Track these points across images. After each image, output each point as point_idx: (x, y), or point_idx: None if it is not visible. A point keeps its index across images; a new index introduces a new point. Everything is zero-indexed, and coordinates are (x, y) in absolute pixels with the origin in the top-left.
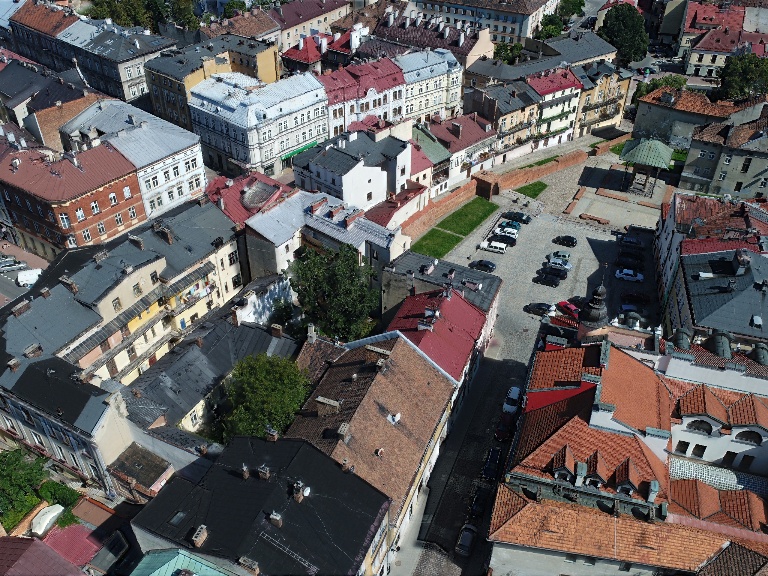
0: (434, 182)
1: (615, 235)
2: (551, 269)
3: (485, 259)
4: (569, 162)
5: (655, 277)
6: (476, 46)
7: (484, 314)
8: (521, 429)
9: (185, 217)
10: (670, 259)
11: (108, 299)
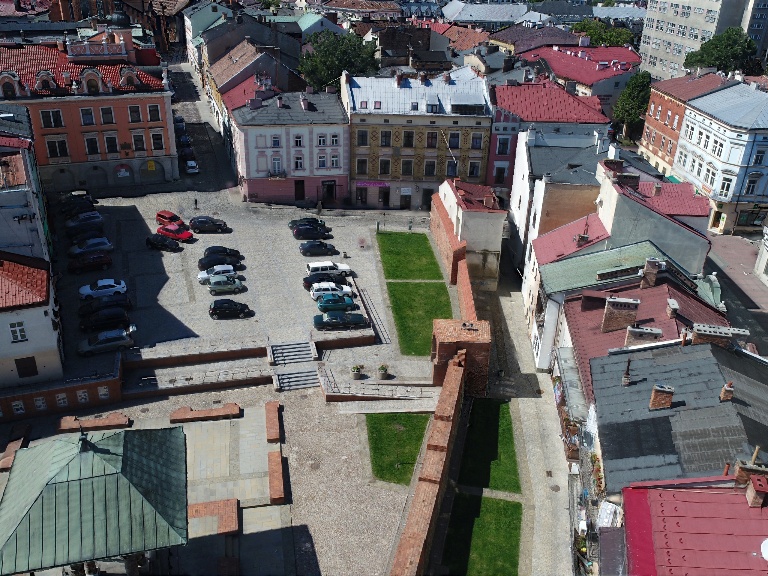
0: None
1: None
2: None
3: None
4: None
5: None
6: None
7: None
8: None
9: None
10: None
11: None
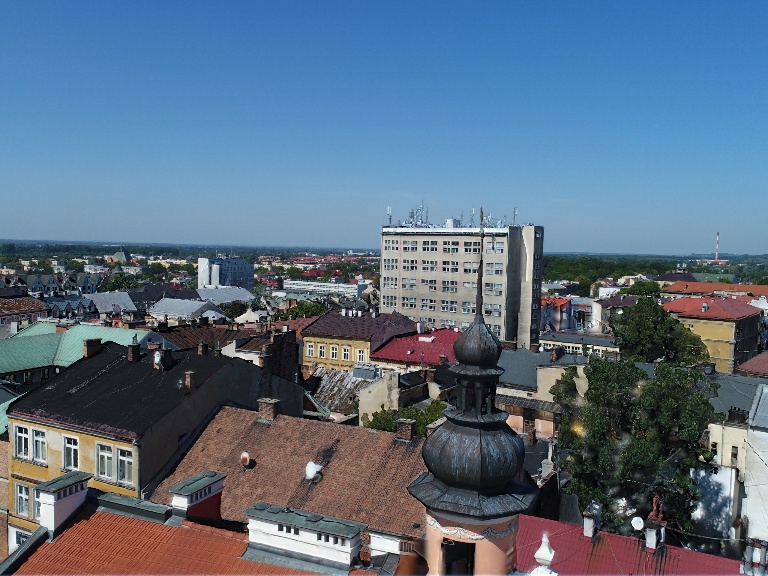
0: None
1: None
2: None
3: None
4: None
5: None
6: None
7: None
8: None
9: (751, 381)
10: None
11: (553, 373)
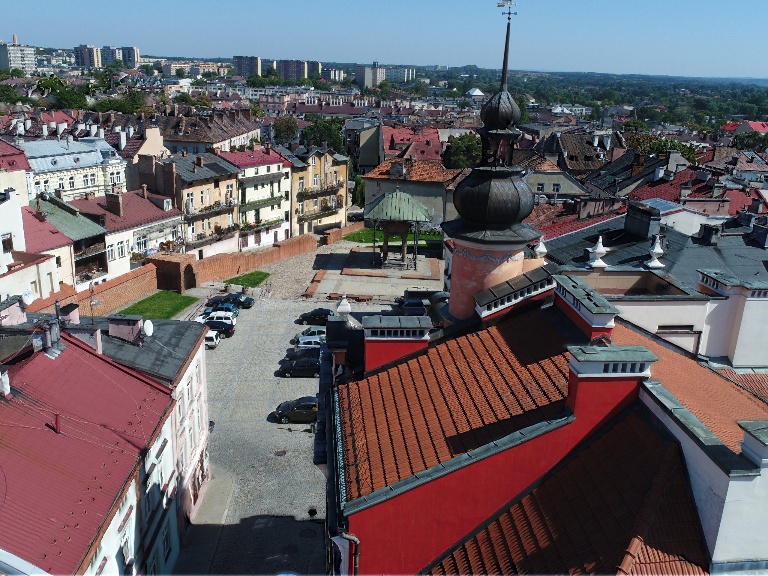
0: (81, 278)
1: (387, 306)
2: (304, 351)
3: None
4: (294, 249)
5: None
6: (144, 148)
7: (165, 389)
8: None
9: None
10: None
11: None
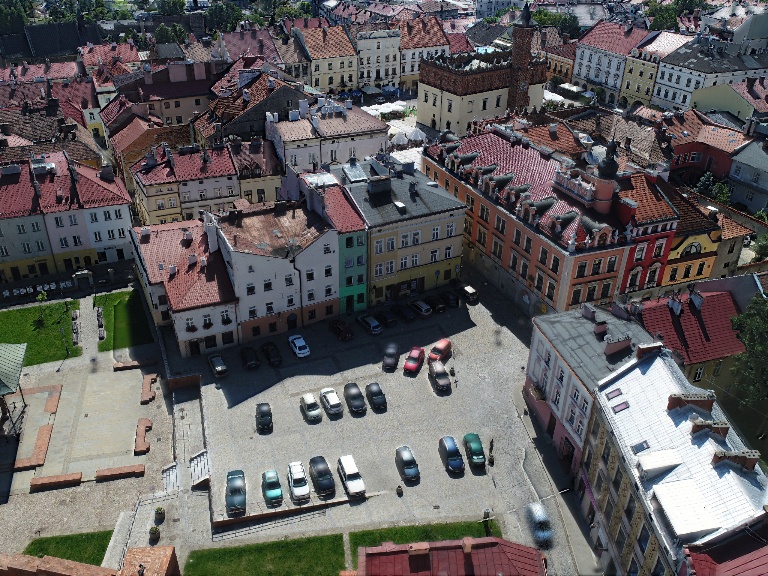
0: None
1: None
2: (357, 396)
3: (384, 476)
4: None
5: (281, 333)
6: None
7: None
8: (687, 233)
9: None
10: (317, 275)
11: None
